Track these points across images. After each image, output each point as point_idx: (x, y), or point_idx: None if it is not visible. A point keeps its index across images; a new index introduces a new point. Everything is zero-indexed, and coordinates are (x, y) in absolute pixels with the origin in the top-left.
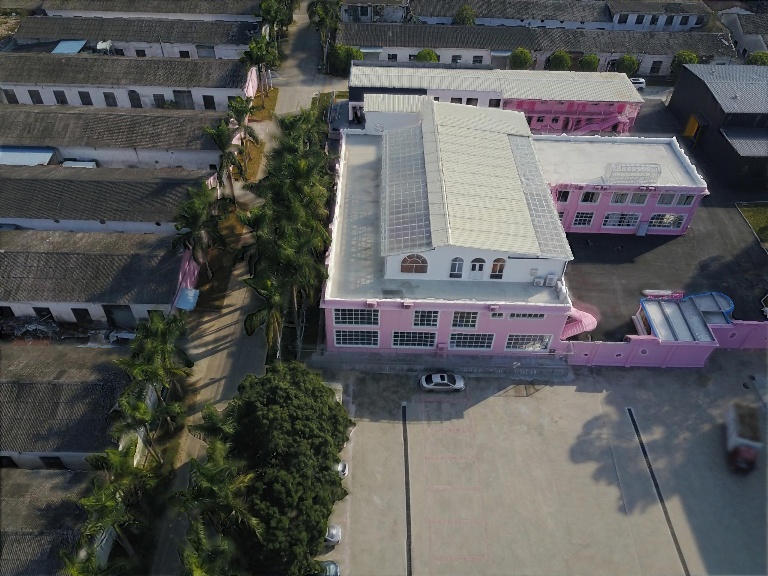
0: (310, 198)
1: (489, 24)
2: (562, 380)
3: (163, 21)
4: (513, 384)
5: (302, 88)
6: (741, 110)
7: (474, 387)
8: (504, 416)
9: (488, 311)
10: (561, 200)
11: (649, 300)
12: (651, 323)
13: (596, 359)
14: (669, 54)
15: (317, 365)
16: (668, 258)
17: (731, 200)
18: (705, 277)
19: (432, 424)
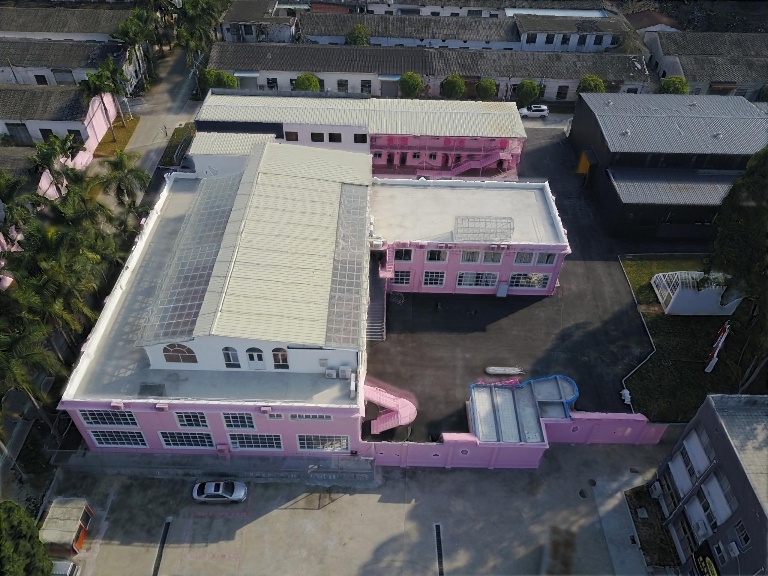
0: (48, 277)
1: (386, 44)
2: (366, 486)
3: (18, 42)
4: (306, 492)
5: (166, 117)
6: (629, 149)
7: (258, 497)
8: (283, 537)
9: (260, 413)
10: (405, 258)
11: (480, 386)
12: (474, 417)
13: (410, 460)
14: (575, 78)
15: (74, 469)
16: (527, 325)
17: (614, 252)
18: (564, 349)
19: (194, 548)
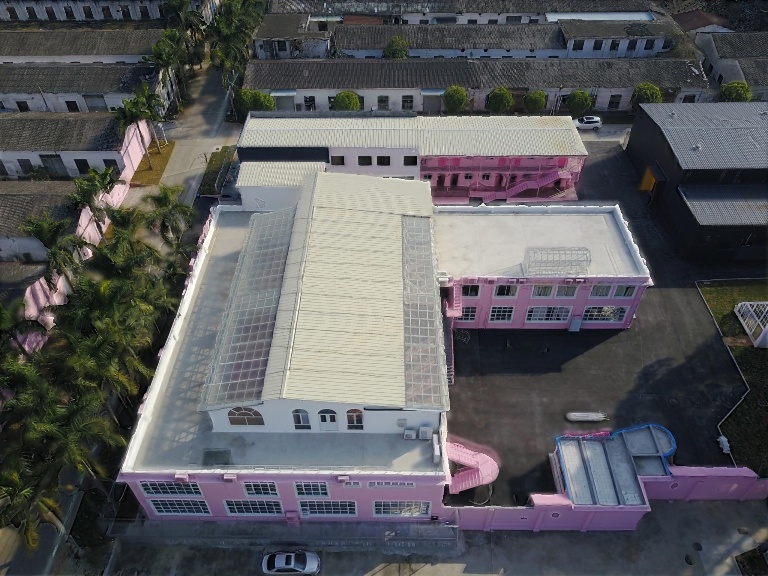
0: (103, 337)
1: (425, 55)
2: (449, 554)
3: (48, 67)
4: (384, 562)
5: (202, 141)
6: (702, 165)
7: (332, 568)
8: None
9: (336, 482)
10: (471, 294)
11: (567, 439)
12: (565, 476)
13: (495, 523)
14: (629, 87)
15: (133, 540)
16: (605, 363)
17: (690, 277)
18: (649, 391)
19: None
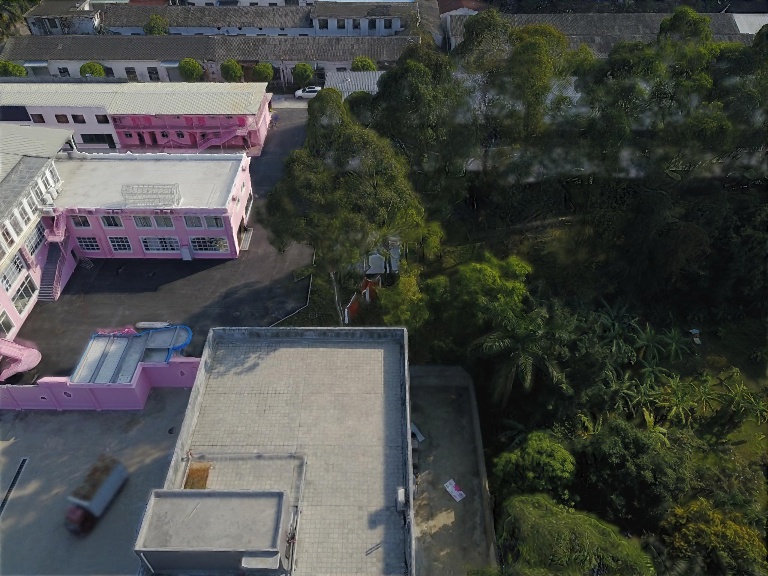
0: None
1: (186, 33)
2: None
3: None
4: None
5: None
6: None
7: None
8: None
9: None
10: (85, 225)
11: (101, 336)
12: None
13: (22, 403)
14: (349, 60)
15: None
16: (198, 285)
17: None
18: (221, 306)
19: None
